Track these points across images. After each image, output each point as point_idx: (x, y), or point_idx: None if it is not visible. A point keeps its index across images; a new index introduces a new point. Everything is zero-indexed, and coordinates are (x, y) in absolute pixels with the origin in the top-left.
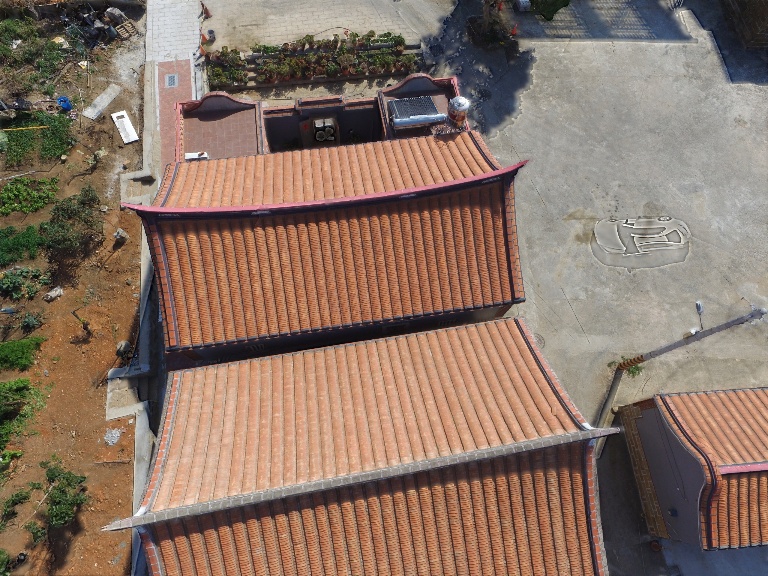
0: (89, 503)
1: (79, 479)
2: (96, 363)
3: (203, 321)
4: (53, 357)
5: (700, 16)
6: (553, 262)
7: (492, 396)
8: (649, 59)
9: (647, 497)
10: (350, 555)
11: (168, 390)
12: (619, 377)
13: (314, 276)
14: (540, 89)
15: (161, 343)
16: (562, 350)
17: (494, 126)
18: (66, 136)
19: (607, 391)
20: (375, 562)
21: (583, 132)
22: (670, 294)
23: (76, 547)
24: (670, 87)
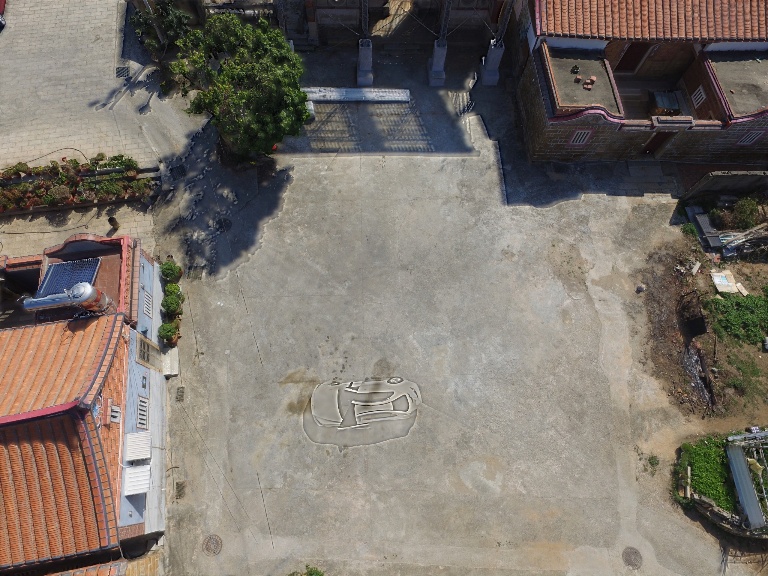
0: None
1: None
2: None
3: None
4: None
5: (489, 123)
6: (255, 439)
7: None
8: (420, 177)
9: None
10: None
11: None
12: None
13: None
14: (289, 217)
15: None
16: (239, 557)
17: (225, 265)
18: None
19: None
20: None
21: (326, 270)
22: (381, 480)
23: None
24: (436, 212)
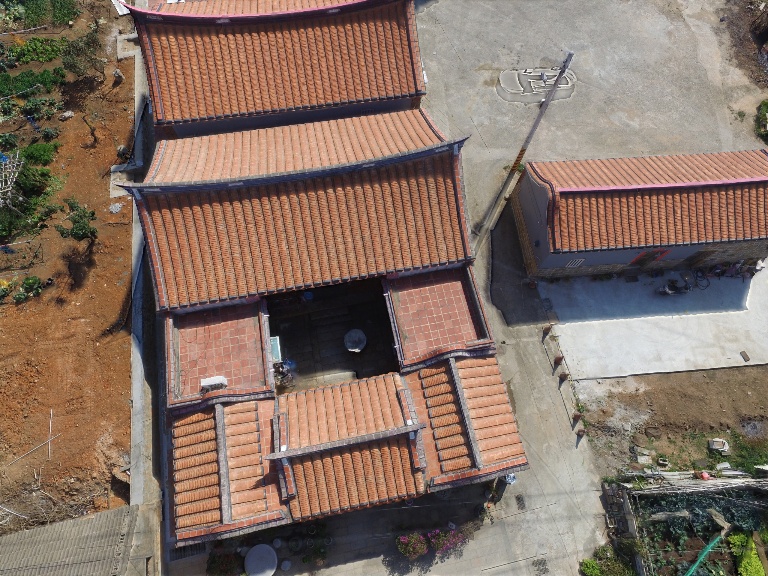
0: (99, 248)
1: (92, 211)
2: (101, 161)
3: (182, 103)
4: (68, 156)
5: None
6: (465, 100)
7: (394, 144)
8: None
9: (526, 250)
10: (287, 234)
11: (156, 150)
12: (512, 176)
13: (265, 72)
14: None
15: (152, 155)
16: (468, 159)
17: (422, 4)
18: (72, 8)
19: (502, 185)
20: (305, 241)
21: (495, 8)
22: (556, 120)
23: (90, 275)
24: None
